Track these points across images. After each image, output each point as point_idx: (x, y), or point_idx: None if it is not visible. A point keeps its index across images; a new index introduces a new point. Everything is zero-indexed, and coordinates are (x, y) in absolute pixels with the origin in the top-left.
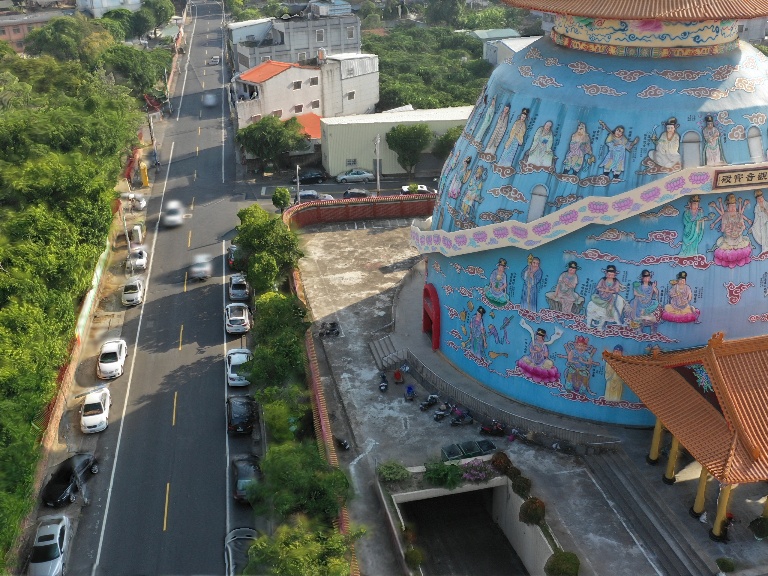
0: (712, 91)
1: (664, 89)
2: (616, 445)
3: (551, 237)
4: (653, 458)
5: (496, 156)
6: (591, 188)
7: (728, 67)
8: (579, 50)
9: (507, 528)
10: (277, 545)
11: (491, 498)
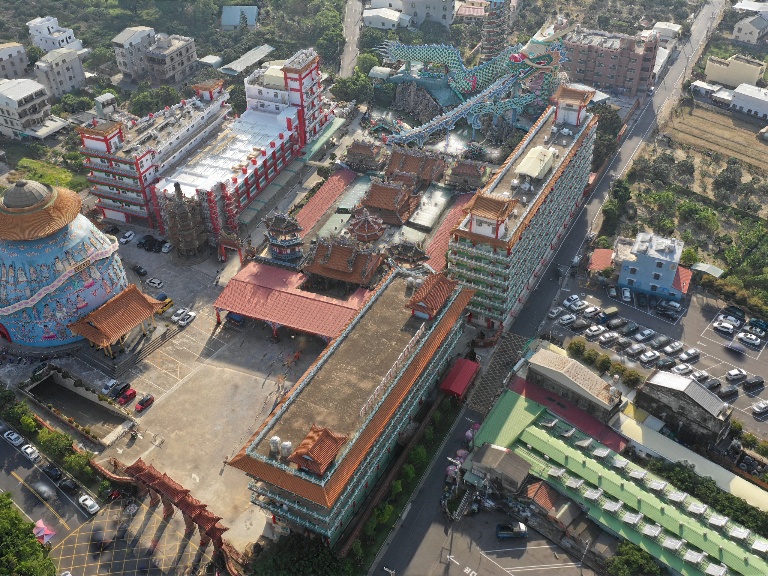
0: (64, 243)
1: (51, 249)
2: (81, 347)
3: (37, 301)
4: (92, 346)
5: (7, 281)
6: (42, 283)
7: (66, 232)
8: (19, 240)
9: (61, 383)
10: (8, 411)
11: (53, 378)
